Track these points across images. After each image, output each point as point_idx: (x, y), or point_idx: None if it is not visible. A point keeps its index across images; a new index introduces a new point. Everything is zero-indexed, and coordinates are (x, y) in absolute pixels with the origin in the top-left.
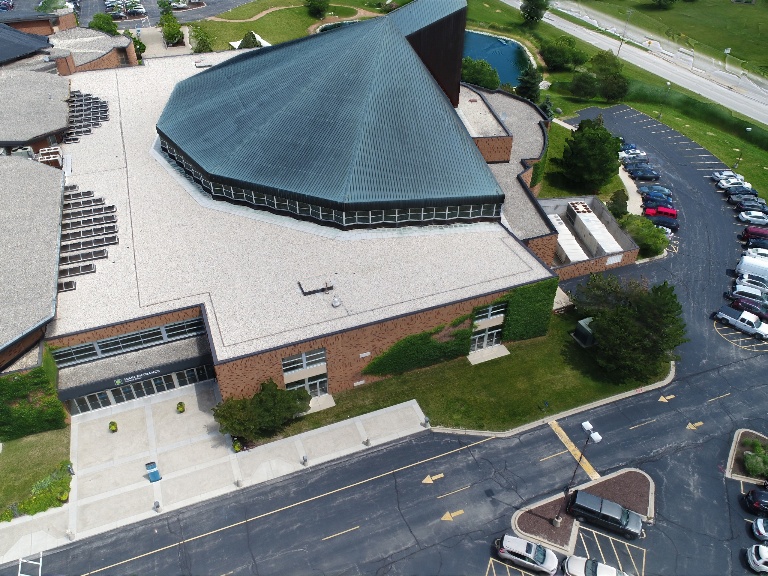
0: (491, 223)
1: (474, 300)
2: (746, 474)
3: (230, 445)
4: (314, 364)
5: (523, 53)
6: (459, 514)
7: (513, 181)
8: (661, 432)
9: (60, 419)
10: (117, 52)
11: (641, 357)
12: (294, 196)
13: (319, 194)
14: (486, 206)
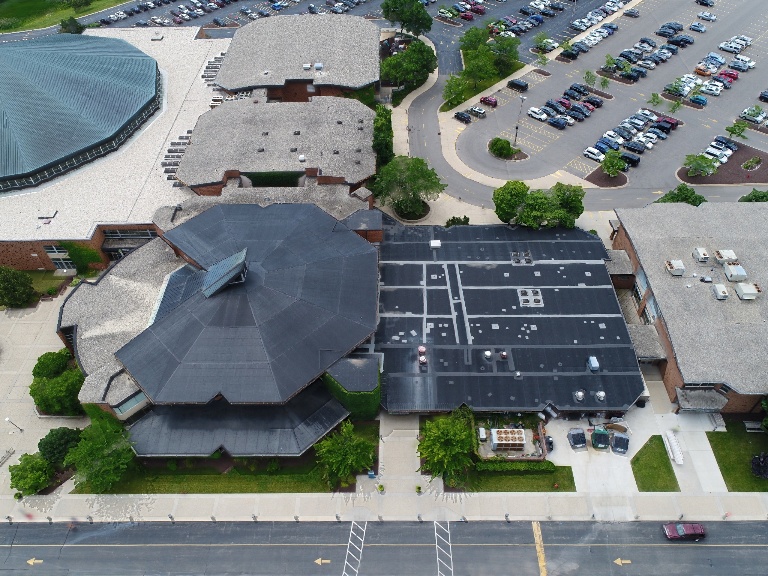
0: None
1: None
2: None
3: None
4: None
5: None
6: None
7: None
8: None
9: None
10: None
11: None
12: None
13: None
14: None
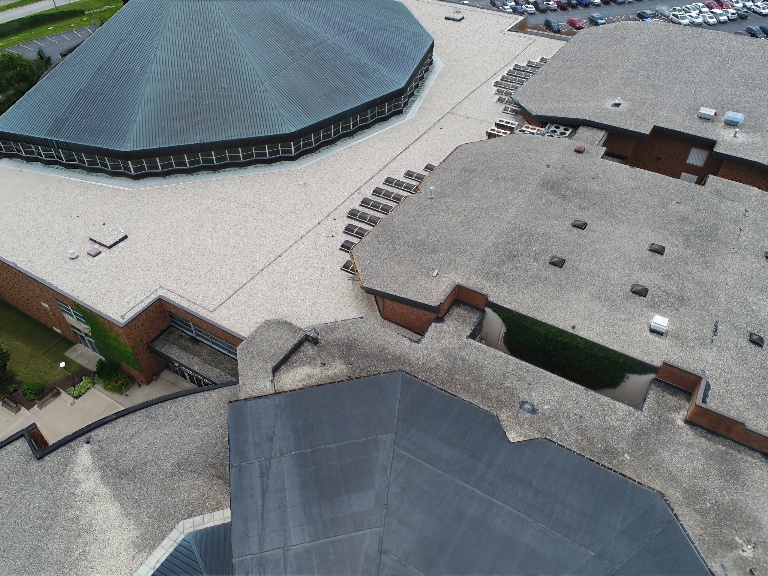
0: None
1: None
2: None
3: None
4: None
5: None
6: None
7: None
8: None
9: None
10: None
11: None
12: None
13: (406, 8)
14: None
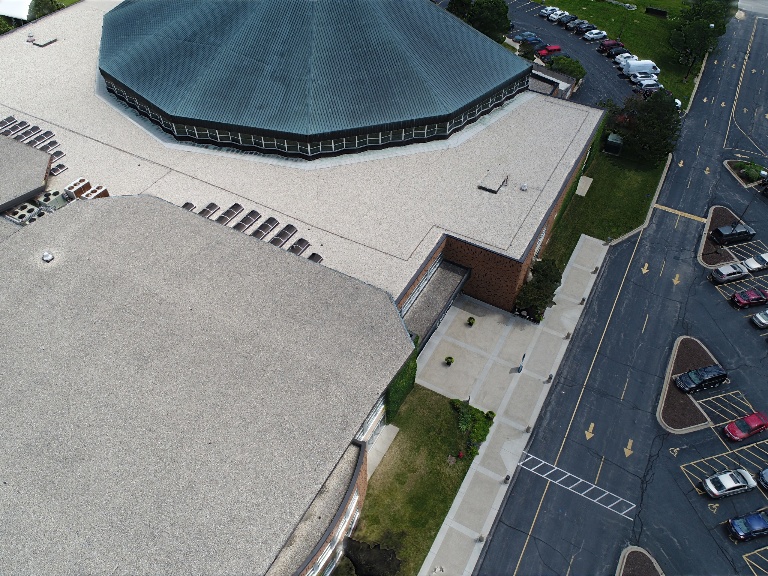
0: (524, 92)
1: None
2: (751, 182)
3: (529, 322)
4: None
5: None
6: (679, 277)
7: None
8: (700, 182)
9: None
10: None
11: None
12: (401, 125)
13: (424, 114)
14: (521, 79)
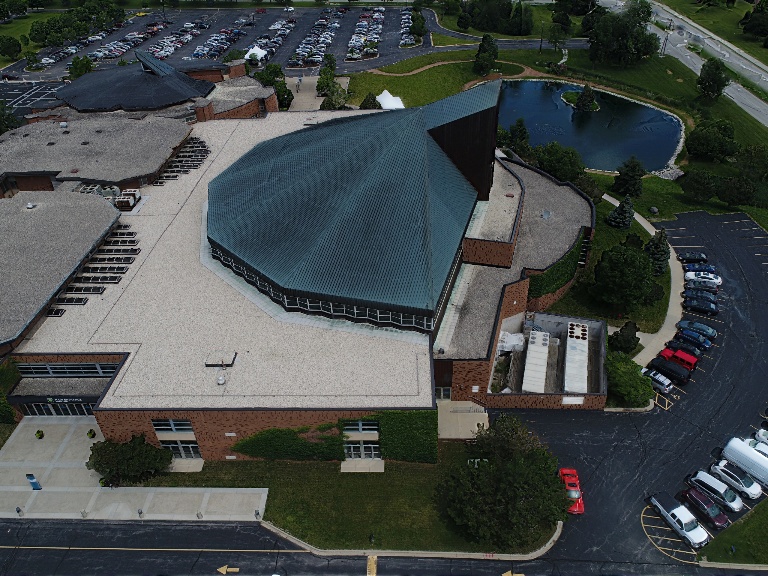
0: (422, 334)
1: (338, 412)
2: None
3: None
4: (183, 430)
5: (678, 132)
6: None
7: (496, 290)
8: None
9: (9, 417)
10: (259, 102)
11: (492, 521)
12: (255, 271)
13: (270, 274)
14: (417, 317)
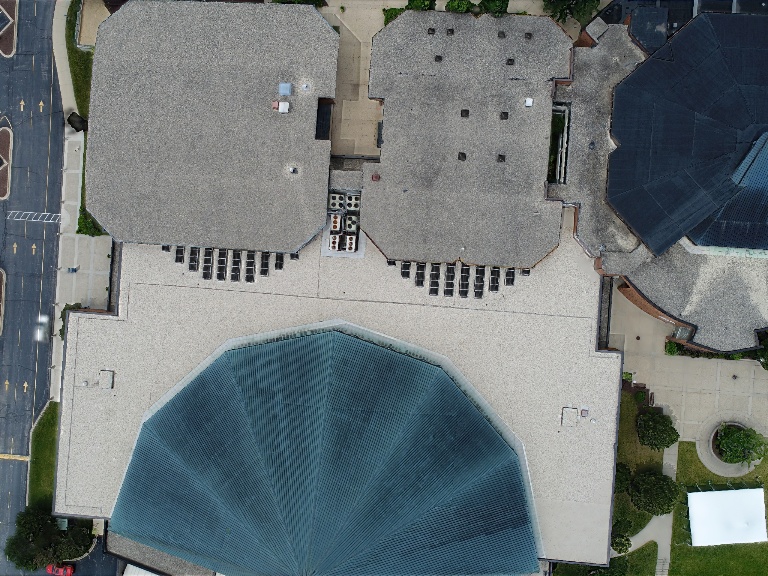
0: None
1: None
2: None
3: None
4: None
5: None
6: (6, 388)
7: (182, 575)
8: (2, 504)
9: None
10: None
11: None
12: None
13: (159, 413)
14: None
